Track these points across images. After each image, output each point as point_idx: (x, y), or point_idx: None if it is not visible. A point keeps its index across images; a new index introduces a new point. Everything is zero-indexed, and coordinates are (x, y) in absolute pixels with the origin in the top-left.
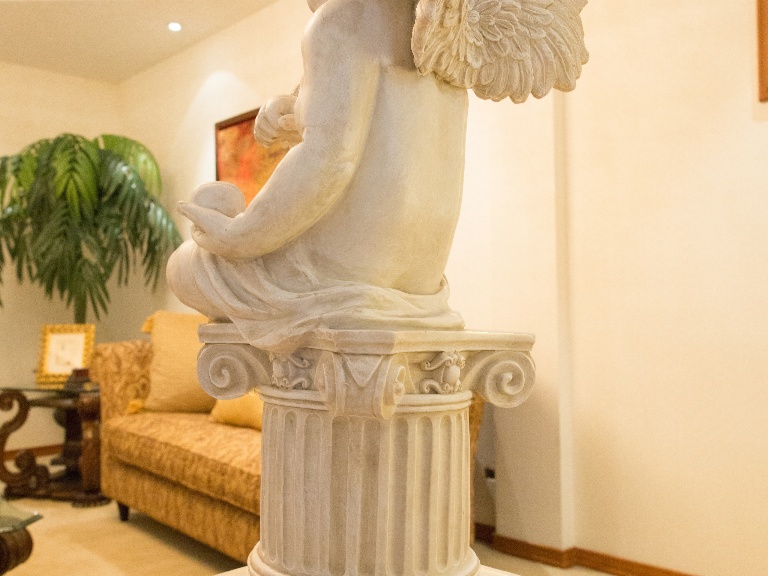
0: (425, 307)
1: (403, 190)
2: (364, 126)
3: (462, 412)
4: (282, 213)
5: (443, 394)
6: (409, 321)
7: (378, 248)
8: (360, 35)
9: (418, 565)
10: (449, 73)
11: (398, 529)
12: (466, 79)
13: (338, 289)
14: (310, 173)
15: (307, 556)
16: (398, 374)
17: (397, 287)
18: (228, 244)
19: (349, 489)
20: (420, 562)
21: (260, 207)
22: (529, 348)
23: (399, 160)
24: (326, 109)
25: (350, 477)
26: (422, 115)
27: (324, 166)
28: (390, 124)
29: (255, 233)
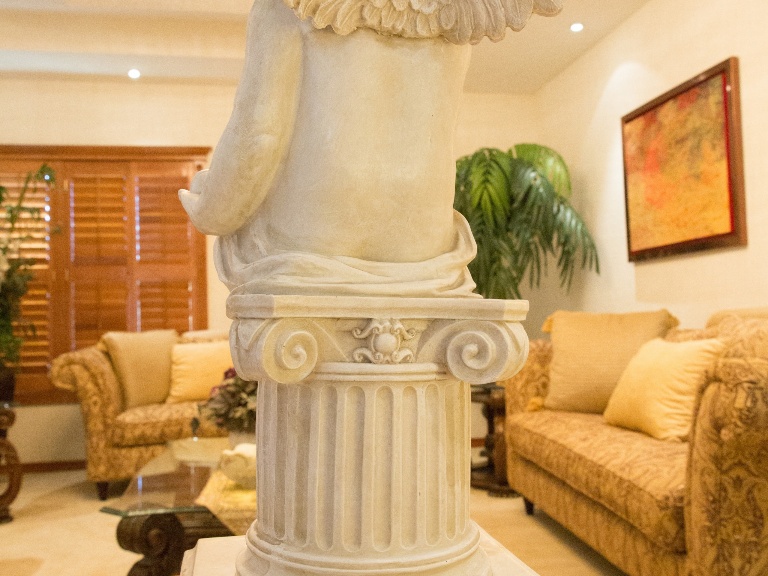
0: (393, 275)
1: (329, 155)
2: (293, 97)
3: (418, 385)
4: (216, 190)
5: (377, 364)
6: (333, 287)
7: (315, 216)
8: (278, 9)
9: (352, 539)
10: (387, 26)
11: (329, 499)
12: (419, 28)
13: (267, 258)
14: (228, 150)
15: (266, 515)
16: (289, 338)
17: (367, 255)
18: (197, 223)
19: (287, 453)
20: (354, 536)
21: (204, 187)
22: (499, 317)
23: (323, 125)
24: (244, 87)
25: (288, 442)
26: (350, 75)
27: (238, 141)
28: (314, 91)
29: (205, 211)
